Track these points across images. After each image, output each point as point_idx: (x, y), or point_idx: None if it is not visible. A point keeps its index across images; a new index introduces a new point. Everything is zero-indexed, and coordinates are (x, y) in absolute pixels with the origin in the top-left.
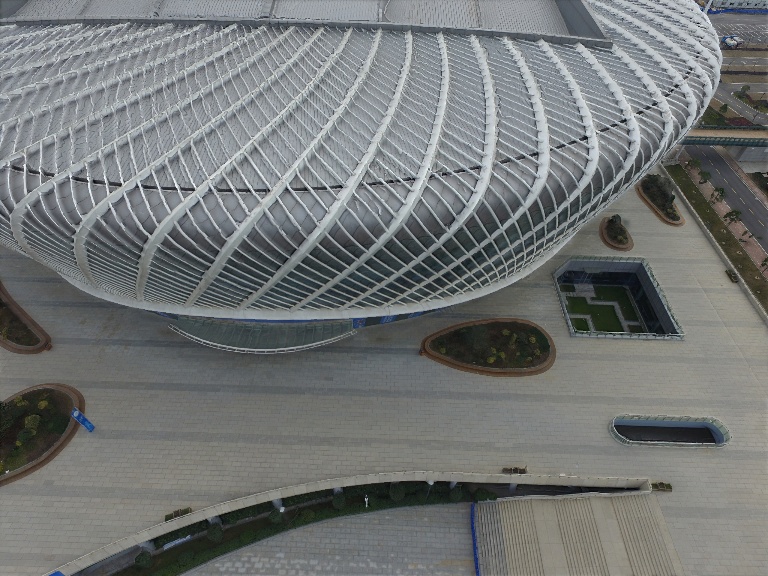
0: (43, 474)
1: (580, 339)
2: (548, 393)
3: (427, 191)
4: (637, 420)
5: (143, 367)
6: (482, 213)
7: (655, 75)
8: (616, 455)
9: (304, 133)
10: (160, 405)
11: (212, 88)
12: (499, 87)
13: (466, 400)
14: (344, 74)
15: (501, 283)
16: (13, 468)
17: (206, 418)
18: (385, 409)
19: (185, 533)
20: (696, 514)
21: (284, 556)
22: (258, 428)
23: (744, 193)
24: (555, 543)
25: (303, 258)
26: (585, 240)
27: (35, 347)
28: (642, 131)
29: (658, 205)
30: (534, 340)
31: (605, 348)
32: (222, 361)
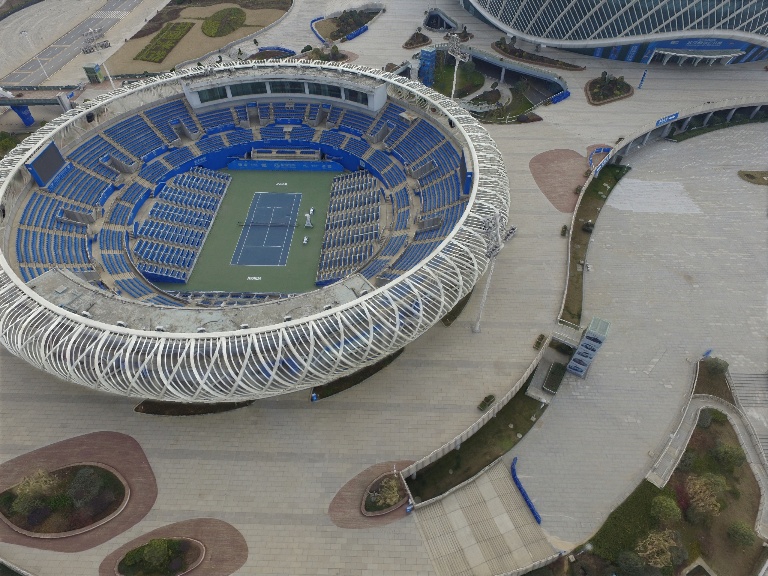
0: (635, 97)
1: None
2: None
3: None
4: None
5: (638, 74)
6: None
7: None
8: None
9: None
10: None
11: None
12: None
13: None
14: None
15: None
16: (622, 94)
17: None
18: None
19: (696, 124)
20: None
21: (744, 130)
22: None
23: None
24: None
25: None
26: None
27: (580, 68)
28: None
29: None
30: None
31: None
32: None
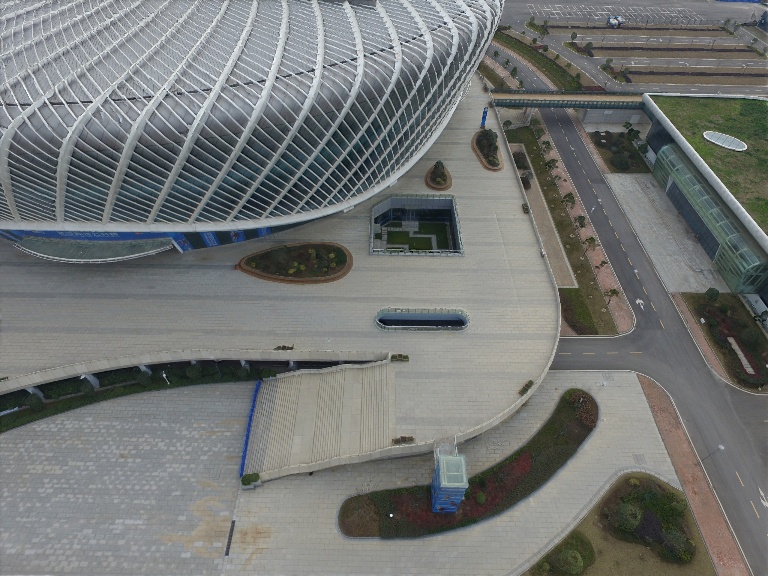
0: None
1: (376, 256)
2: (334, 295)
3: (161, 105)
4: (401, 313)
5: None
6: (213, 125)
7: (403, 26)
8: (373, 337)
9: (74, 64)
10: (2, 308)
11: (12, 33)
12: (255, 32)
13: (263, 301)
14: (128, 23)
15: (315, 212)
16: None
17: (39, 317)
18: (192, 308)
19: (12, 405)
20: (422, 376)
21: (92, 420)
22: (81, 323)
23: (579, 148)
24: (311, 403)
25: (70, 161)
26: (410, 183)
27: None
28: (371, 67)
29: (484, 154)
30: (333, 256)
31: (395, 263)
32: (64, 276)
